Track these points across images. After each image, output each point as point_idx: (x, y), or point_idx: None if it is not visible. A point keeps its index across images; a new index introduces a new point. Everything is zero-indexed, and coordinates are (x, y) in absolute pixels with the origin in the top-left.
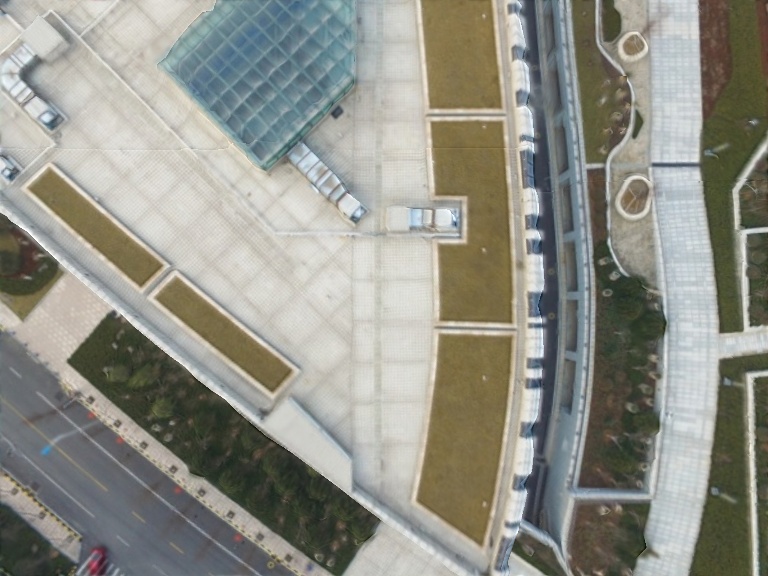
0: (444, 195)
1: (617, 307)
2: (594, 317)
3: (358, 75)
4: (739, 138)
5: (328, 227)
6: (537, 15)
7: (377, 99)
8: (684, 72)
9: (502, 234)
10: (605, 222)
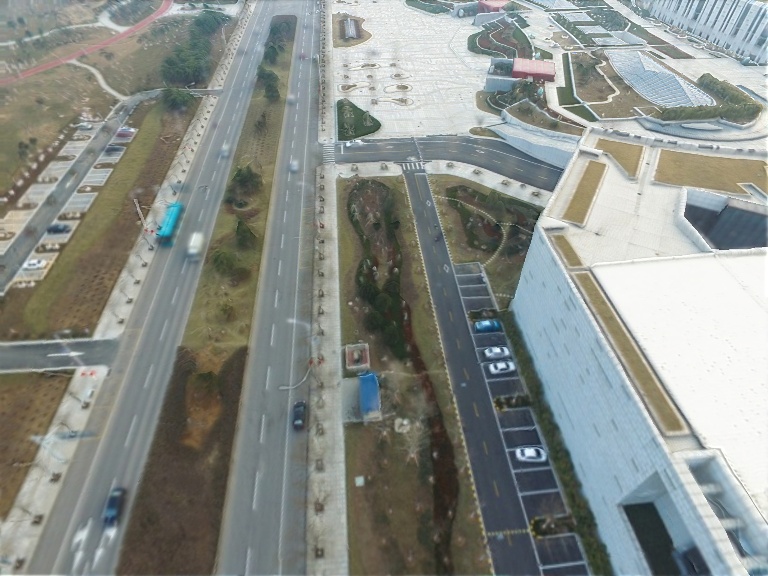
0: None
1: None
2: None
3: None
4: None
5: None
6: None
7: None
8: None
9: None
10: None
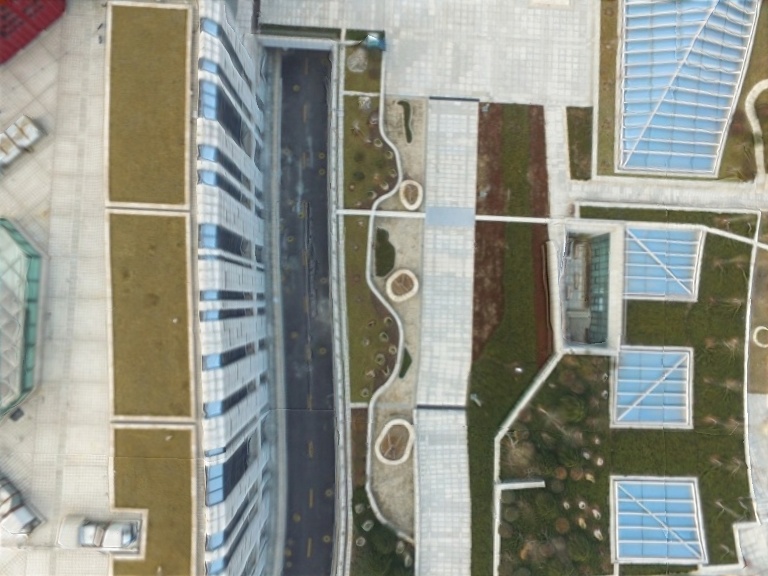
0: (124, 507)
1: (367, 559)
2: (349, 563)
3: (43, 375)
4: (506, 383)
5: (0, 537)
6: (329, 226)
7: (62, 400)
8: (456, 311)
9: (183, 550)
10: (364, 466)
